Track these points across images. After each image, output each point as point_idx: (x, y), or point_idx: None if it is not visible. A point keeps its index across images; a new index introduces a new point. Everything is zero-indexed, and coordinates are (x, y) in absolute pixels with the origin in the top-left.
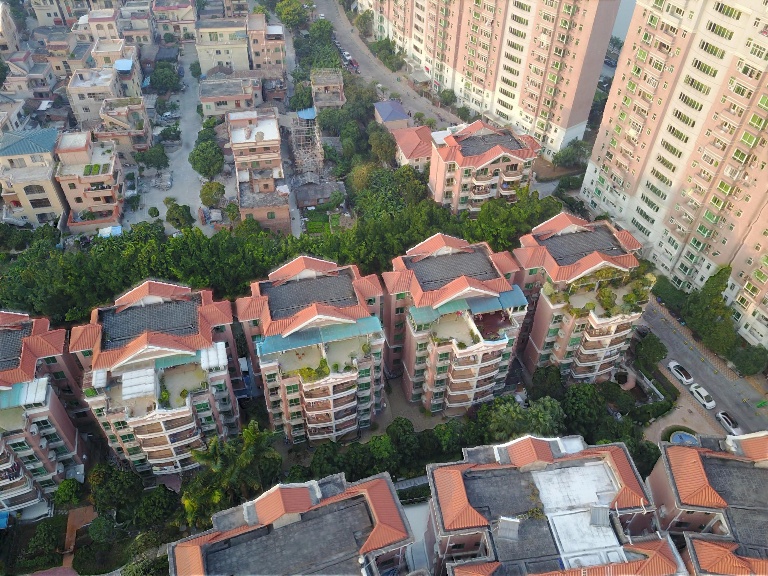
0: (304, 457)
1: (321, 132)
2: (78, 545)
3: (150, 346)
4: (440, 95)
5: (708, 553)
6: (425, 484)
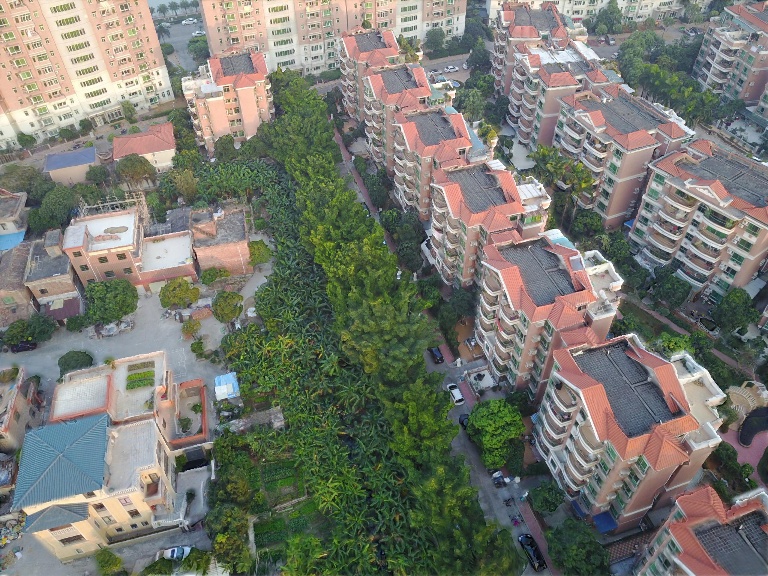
0: None
1: (60, 228)
2: None
3: None
4: (9, 151)
5: (560, 34)
6: None
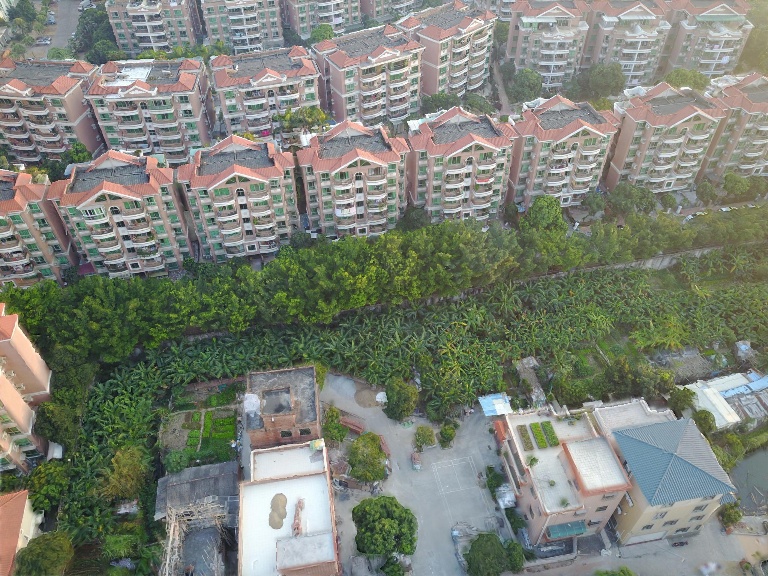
0: None
1: None
2: None
3: (345, 121)
4: None
5: (86, 67)
6: None
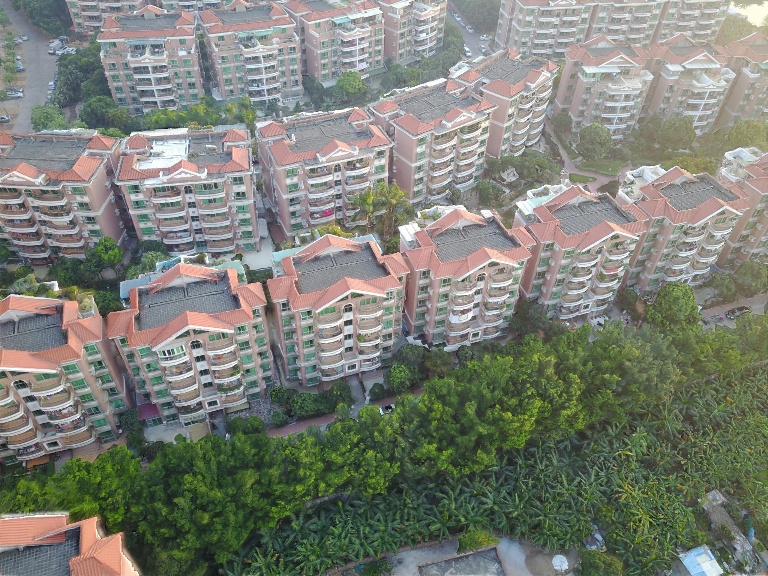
0: None
1: None
2: None
3: (455, 209)
4: None
5: None
6: None
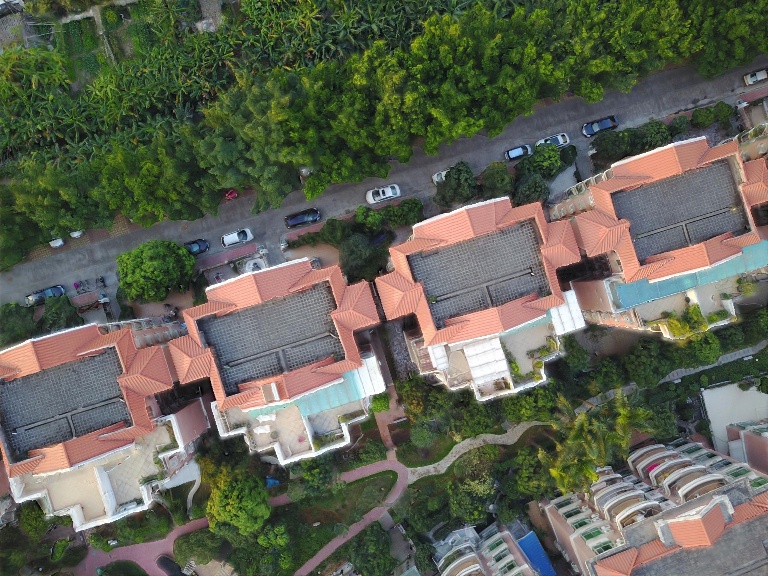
0: (601, 336)
1: None
2: (395, 440)
3: (507, 330)
4: None
5: None
6: (731, 363)
